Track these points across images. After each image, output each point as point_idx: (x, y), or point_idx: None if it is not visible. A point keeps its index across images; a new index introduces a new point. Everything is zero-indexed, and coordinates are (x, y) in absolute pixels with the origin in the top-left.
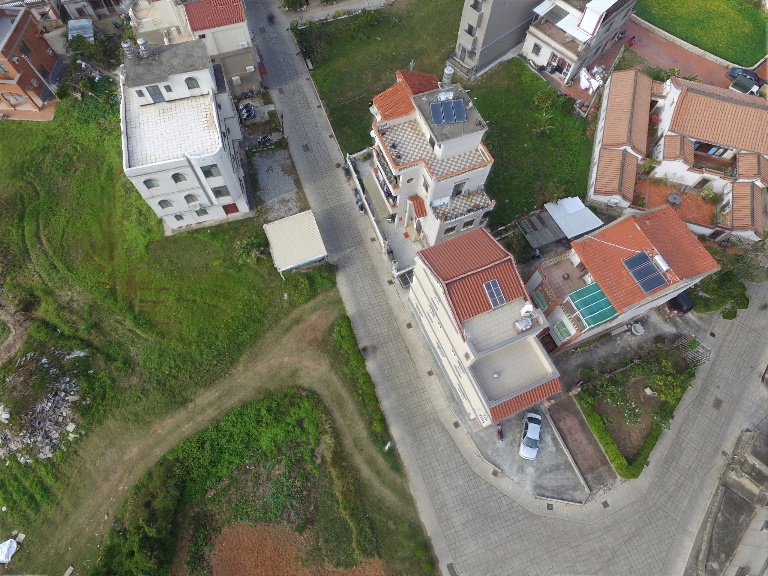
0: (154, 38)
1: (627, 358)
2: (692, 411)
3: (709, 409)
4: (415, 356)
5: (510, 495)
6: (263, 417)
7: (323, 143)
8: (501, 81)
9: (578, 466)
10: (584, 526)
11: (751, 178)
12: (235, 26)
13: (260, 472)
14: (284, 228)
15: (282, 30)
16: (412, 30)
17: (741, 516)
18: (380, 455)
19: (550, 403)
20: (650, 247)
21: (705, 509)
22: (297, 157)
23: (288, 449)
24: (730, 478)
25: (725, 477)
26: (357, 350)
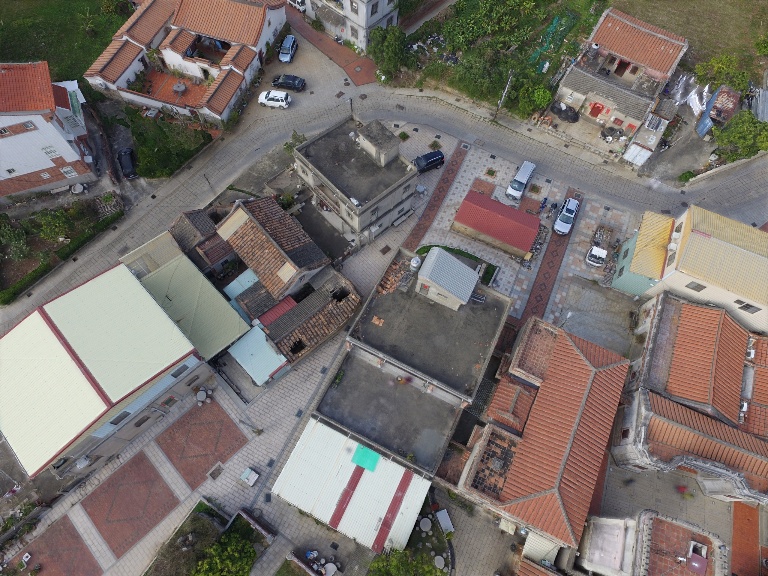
0: None
1: None
2: (97, 256)
3: (113, 254)
4: None
5: None
6: None
7: None
8: None
9: None
10: None
11: (226, 64)
12: None
13: None
14: None
15: None
16: None
17: None
18: None
19: None
20: None
21: None
22: None
23: None
24: None
25: None
26: None
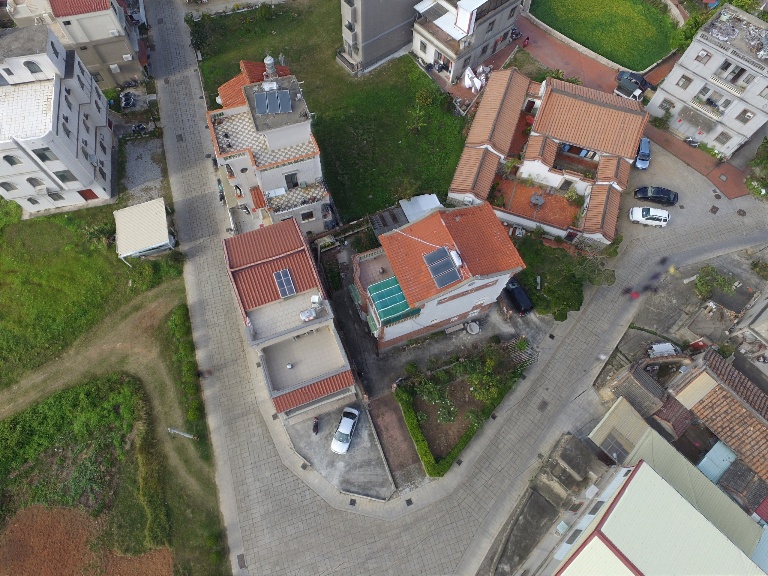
0: (32, 24)
1: (453, 356)
2: (516, 412)
3: (533, 411)
4: (247, 347)
5: (315, 489)
6: (80, 401)
7: (198, 133)
8: (388, 78)
9: (388, 463)
10: (383, 523)
11: (608, 181)
12: (101, 14)
13: (67, 455)
14: (133, 215)
15: (180, 21)
16: (309, 25)
17: (543, 520)
18: (191, 443)
19: (365, 398)
20: (451, 243)
21: (510, 511)
22: (169, 146)
23: (99, 434)
24: (540, 481)
25: (536, 480)
26: (190, 339)
